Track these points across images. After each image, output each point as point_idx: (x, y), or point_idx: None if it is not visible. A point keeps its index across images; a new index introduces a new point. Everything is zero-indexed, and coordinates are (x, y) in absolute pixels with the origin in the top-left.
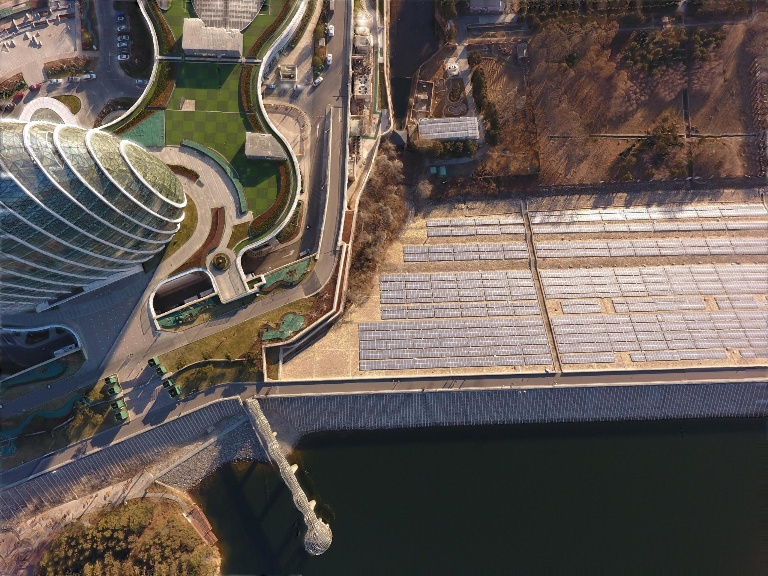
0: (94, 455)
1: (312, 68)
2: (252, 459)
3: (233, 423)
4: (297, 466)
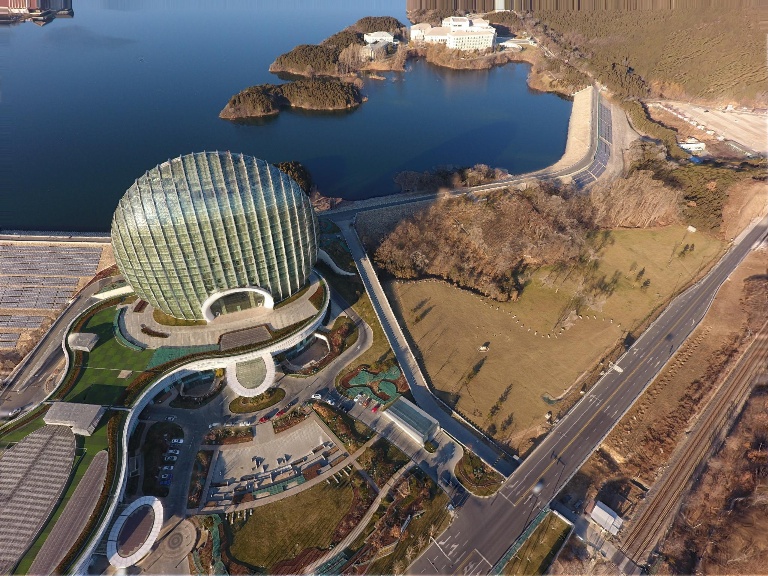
0: None
1: None
2: None
3: None
4: None
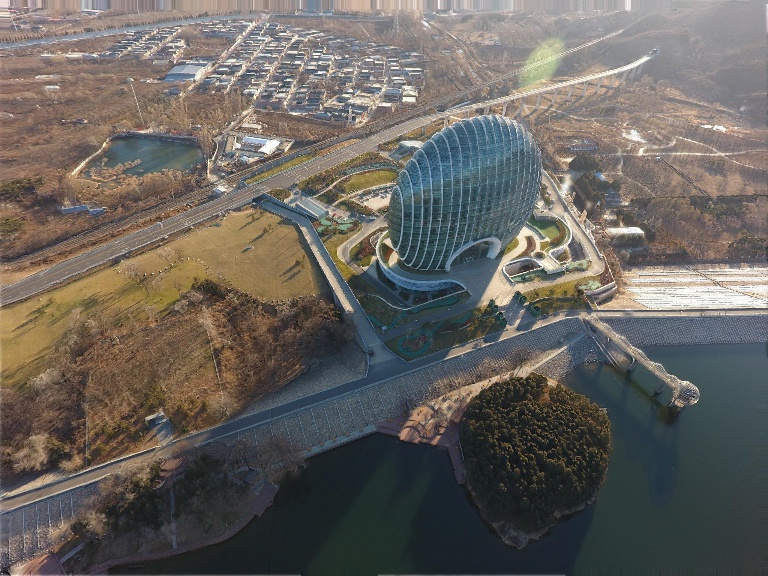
0: (487, 349)
1: (545, 203)
2: (598, 362)
3: (577, 336)
4: None
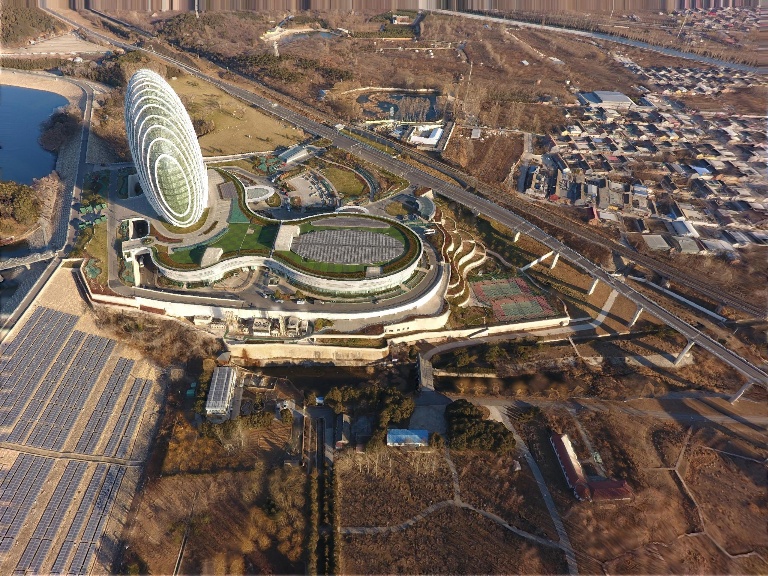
0: None
1: None
2: None
3: None
4: (1, 281)
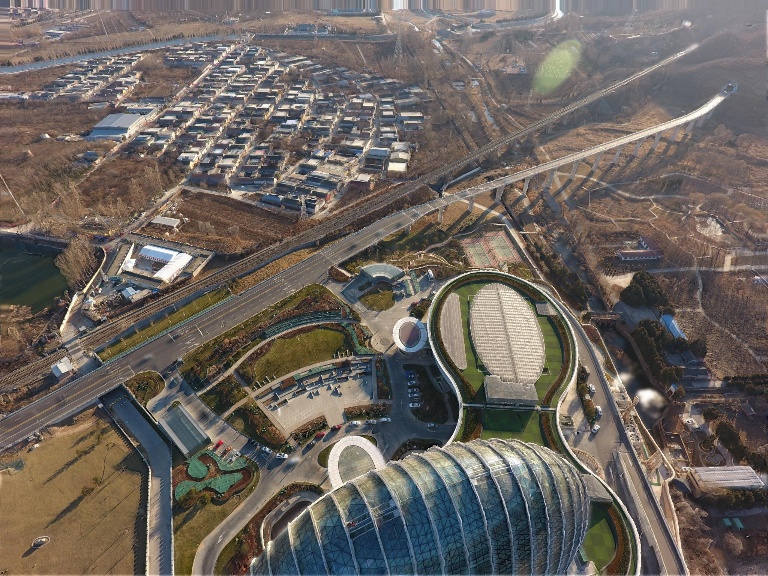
0: None
1: (586, 417)
2: None
3: None
4: None
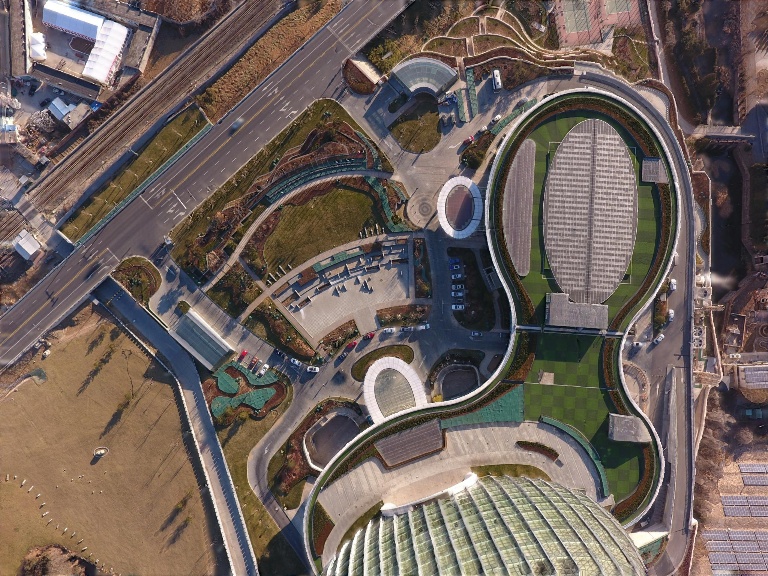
0: None
1: (652, 324)
2: None
3: None
4: None
